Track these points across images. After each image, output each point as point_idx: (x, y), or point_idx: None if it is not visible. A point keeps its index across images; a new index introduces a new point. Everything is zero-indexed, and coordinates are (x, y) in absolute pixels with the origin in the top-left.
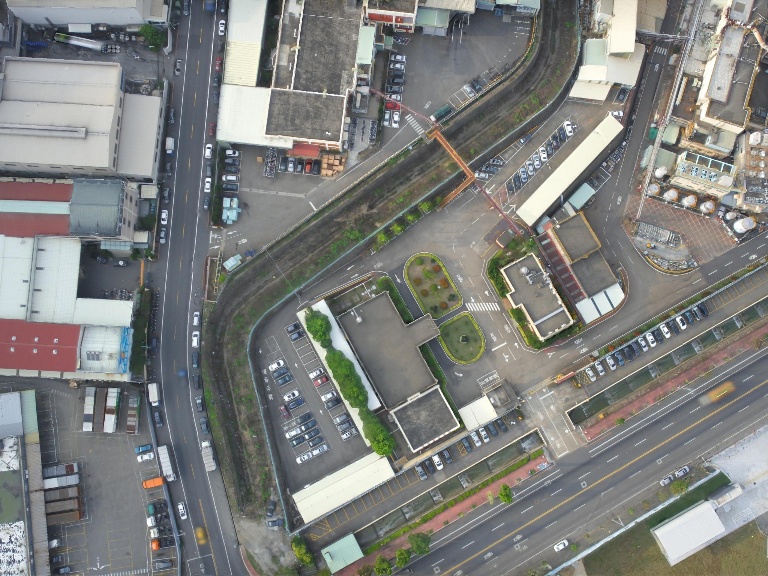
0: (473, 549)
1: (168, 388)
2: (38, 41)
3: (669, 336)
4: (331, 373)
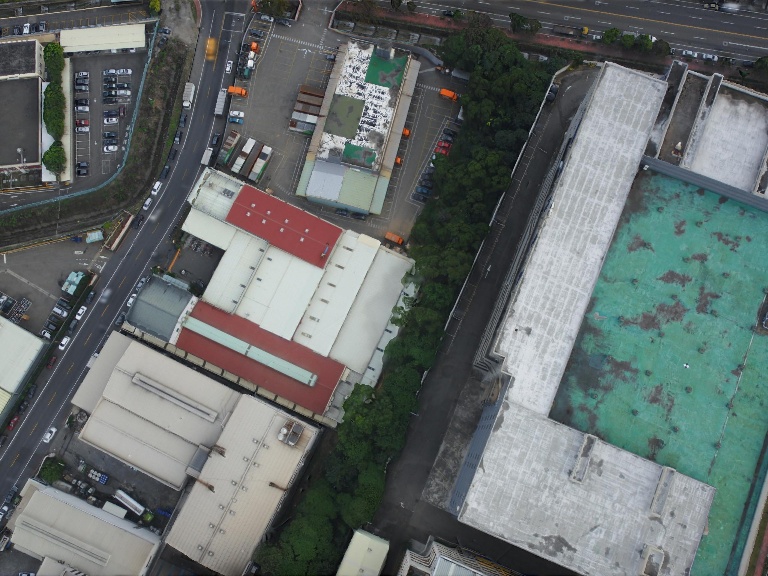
0: None
1: (198, 160)
2: (164, 519)
3: None
4: (68, 122)
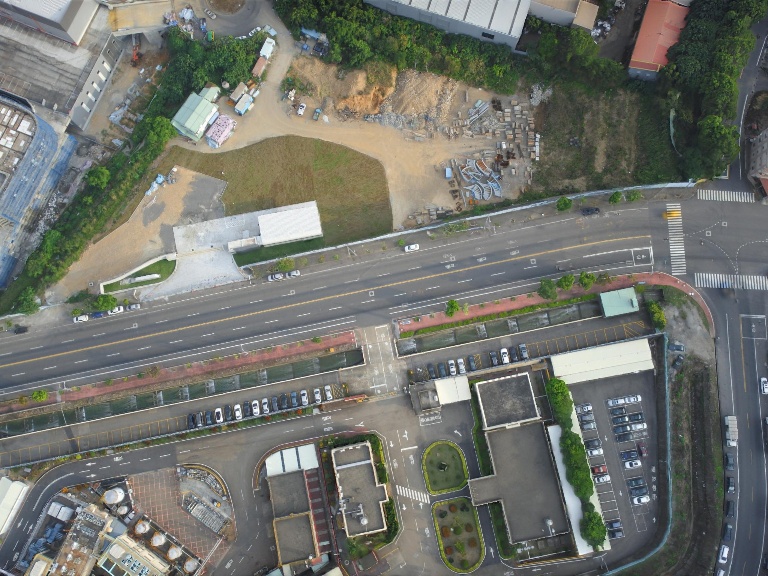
0: (494, 269)
1: (760, 512)
2: None
3: (236, 406)
4: None
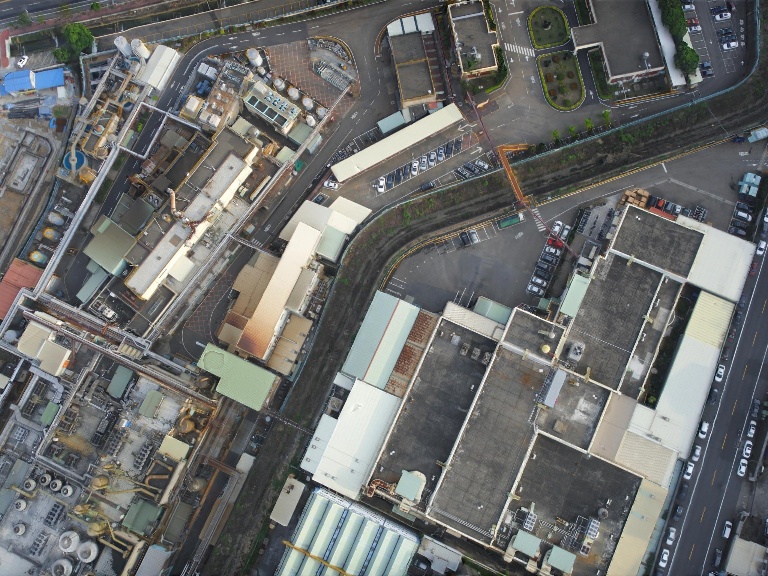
0: None
1: None
2: None
3: None
4: None
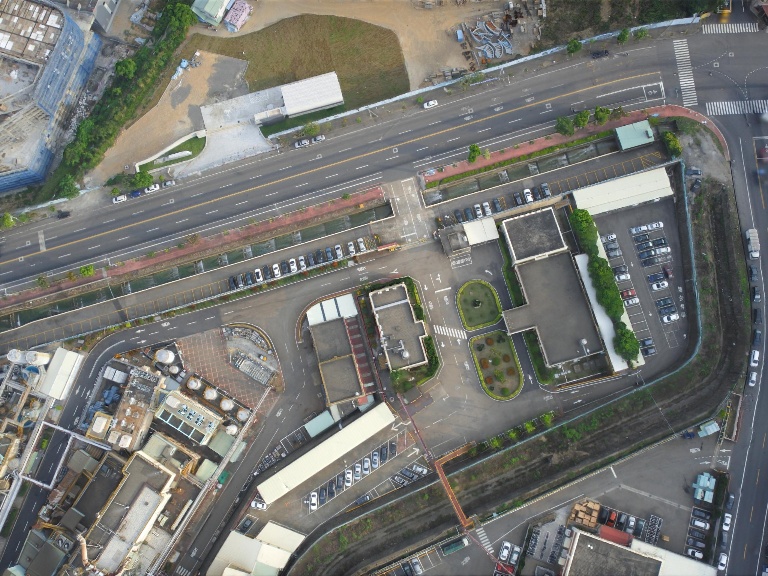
0: (512, 117)
1: None
2: None
3: (274, 266)
4: None
